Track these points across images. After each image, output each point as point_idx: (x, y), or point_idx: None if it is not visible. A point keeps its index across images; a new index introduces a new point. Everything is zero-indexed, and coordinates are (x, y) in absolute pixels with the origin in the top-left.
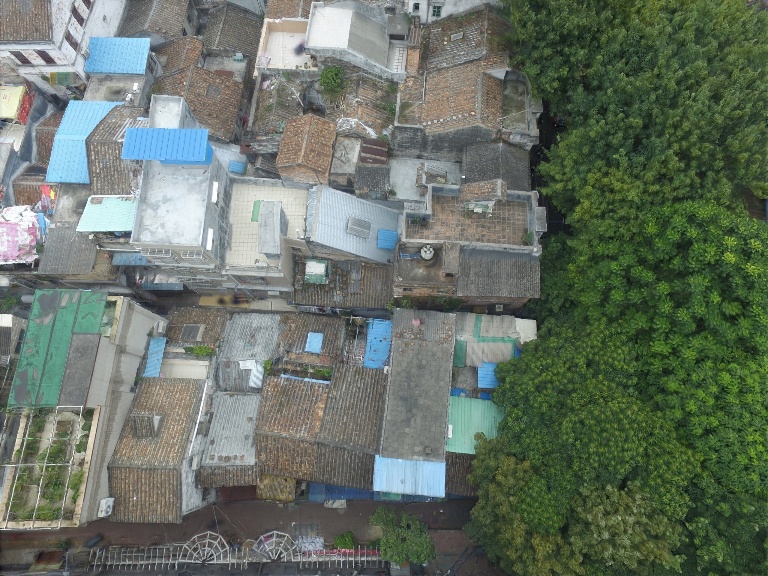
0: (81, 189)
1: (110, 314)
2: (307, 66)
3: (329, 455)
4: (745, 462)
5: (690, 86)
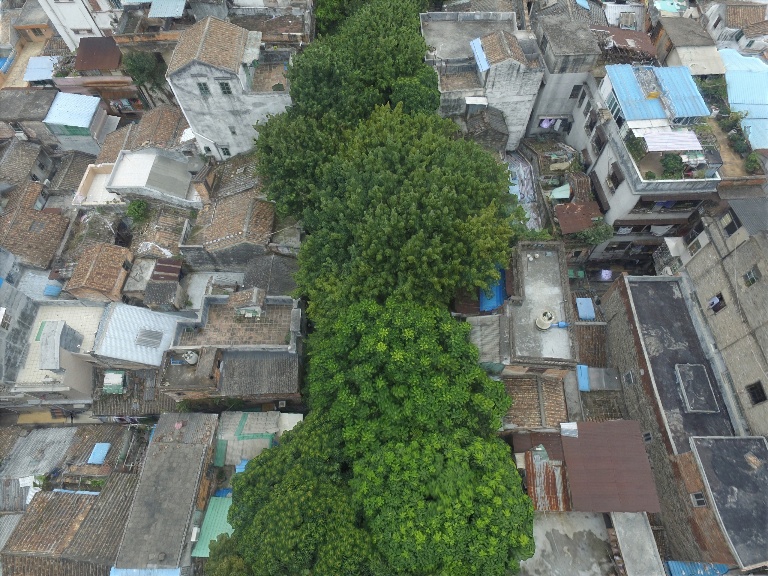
0: None
1: None
2: (116, 201)
3: (75, 571)
4: (398, 539)
5: (372, 204)
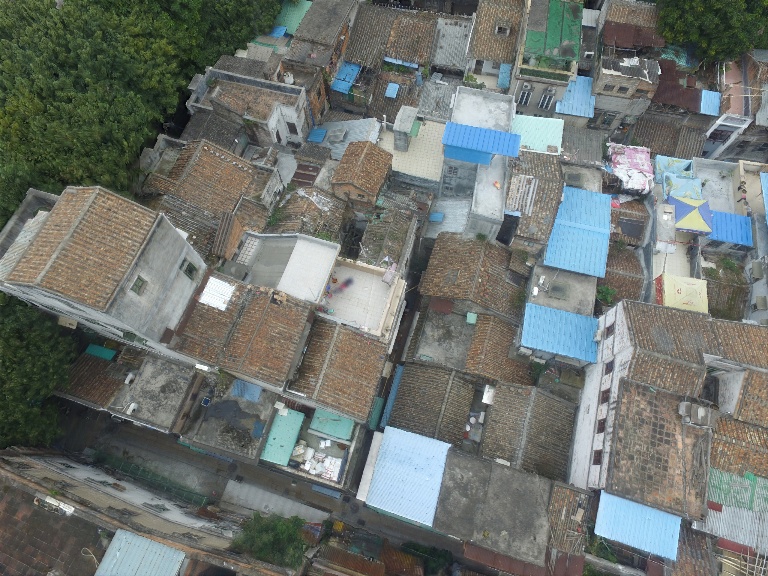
0: None
1: None
2: (344, 260)
3: None
4: None
5: None
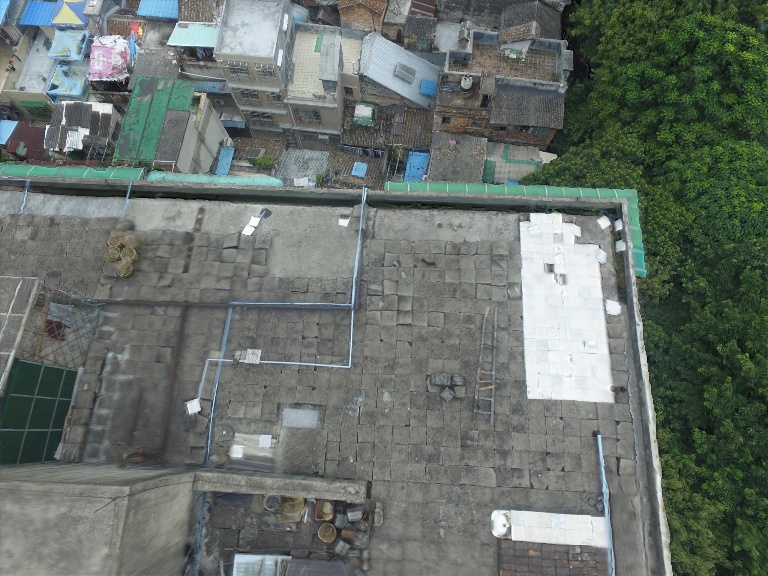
0: (166, 26)
1: (193, 110)
2: None
3: None
4: (729, 210)
5: None
